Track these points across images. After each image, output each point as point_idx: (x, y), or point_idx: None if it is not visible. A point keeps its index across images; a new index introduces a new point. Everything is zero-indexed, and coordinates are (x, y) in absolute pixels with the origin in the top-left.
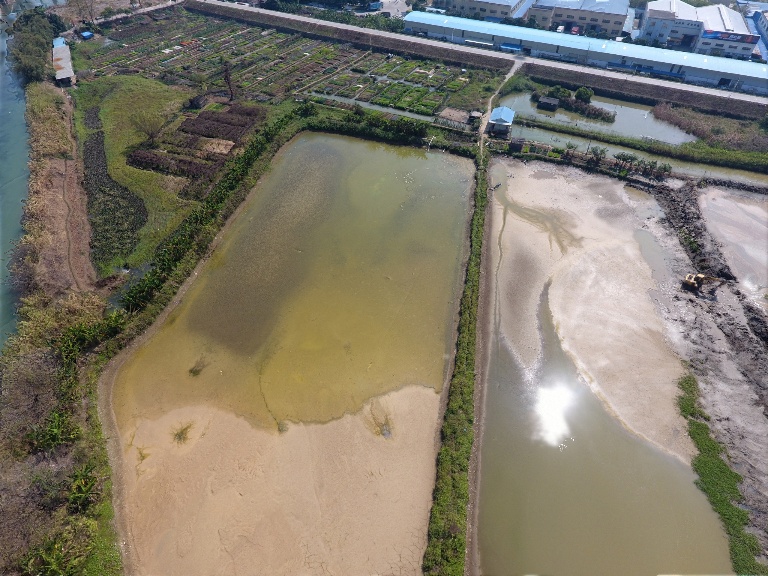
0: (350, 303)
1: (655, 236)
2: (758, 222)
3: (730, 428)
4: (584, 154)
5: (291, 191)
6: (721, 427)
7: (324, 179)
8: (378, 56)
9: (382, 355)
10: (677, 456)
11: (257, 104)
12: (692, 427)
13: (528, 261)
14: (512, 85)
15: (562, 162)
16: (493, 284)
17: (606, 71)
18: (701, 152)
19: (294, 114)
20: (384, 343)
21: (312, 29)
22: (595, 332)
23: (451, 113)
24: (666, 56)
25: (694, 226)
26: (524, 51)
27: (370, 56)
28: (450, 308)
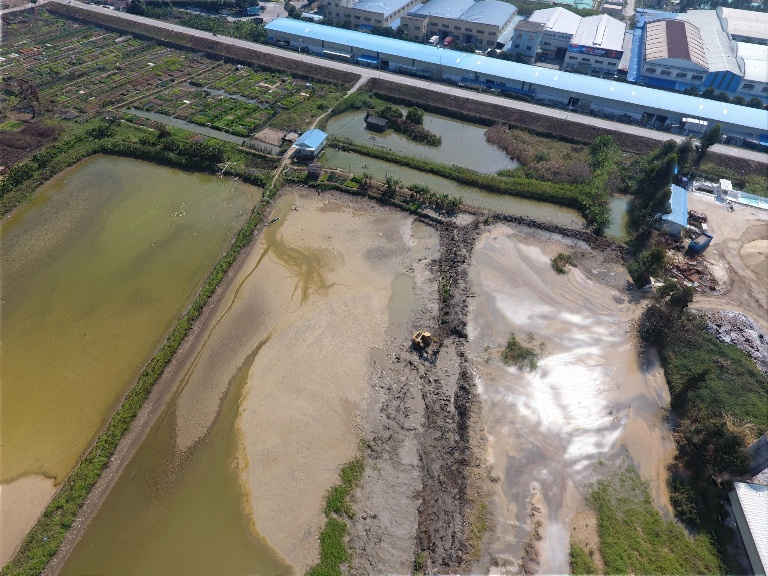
0: (22, 368)
1: (415, 282)
2: (528, 267)
3: (371, 528)
4: (383, 184)
5: (38, 227)
6: (362, 527)
7: (84, 212)
8: (227, 67)
9: (20, 435)
10: (292, 567)
11: (58, 123)
12: (327, 528)
13: (257, 313)
14: (348, 103)
15: (357, 193)
16: (201, 342)
17: (452, 88)
18: (509, 182)
19: (88, 135)
20: (31, 420)
21: (168, 36)
22: (283, 403)
23: (267, 134)
24: (518, 72)
25: (455, 272)
26: (380, 64)
27: (219, 67)
28: (134, 373)
